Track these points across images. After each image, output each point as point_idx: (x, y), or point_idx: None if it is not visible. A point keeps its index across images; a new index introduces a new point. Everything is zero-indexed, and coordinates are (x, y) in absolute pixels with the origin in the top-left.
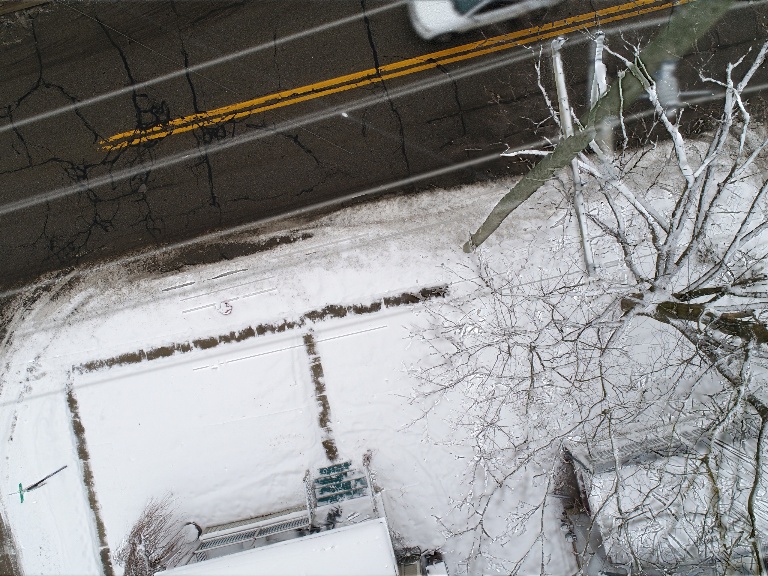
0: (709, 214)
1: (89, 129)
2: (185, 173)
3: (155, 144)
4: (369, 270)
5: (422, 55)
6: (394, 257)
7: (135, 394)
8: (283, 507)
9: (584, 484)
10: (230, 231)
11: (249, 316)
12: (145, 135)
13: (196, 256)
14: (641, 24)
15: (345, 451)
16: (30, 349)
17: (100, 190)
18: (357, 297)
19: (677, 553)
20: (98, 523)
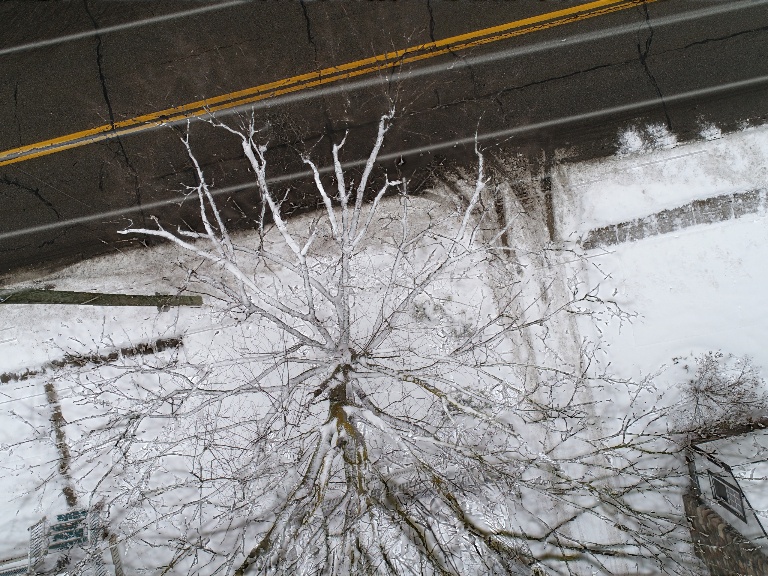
0: None
1: None
2: None
3: None
4: None
5: (155, 112)
6: (128, 309)
7: None
8: (22, 553)
9: None
10: None
11: None
12: None
13: None
14: (364, 83)
15: (83, 498)
16: None
17: None
18: (94, 348)
19: None
20: None
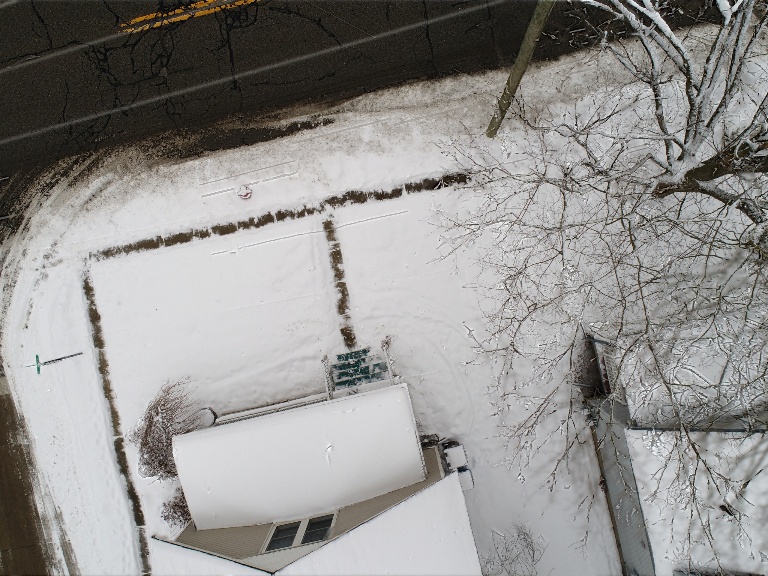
0: (743, 62)
1: (110, 12)
2: (206, 57)
3: (177, 27)
4: (391, 154)
5: None
6: (416, 141)
7: (152, 279)
8: (300, 394)
9: (606, 367)
10: (251, 116)
11: (269, 201)
12: (167, 18)
13: (216, 141)
14: None
15: (363, 338)
16: (47, 235)
17: (120, 74)
18: (378, 182)
19: (706, 405)
20: (112, 412)
